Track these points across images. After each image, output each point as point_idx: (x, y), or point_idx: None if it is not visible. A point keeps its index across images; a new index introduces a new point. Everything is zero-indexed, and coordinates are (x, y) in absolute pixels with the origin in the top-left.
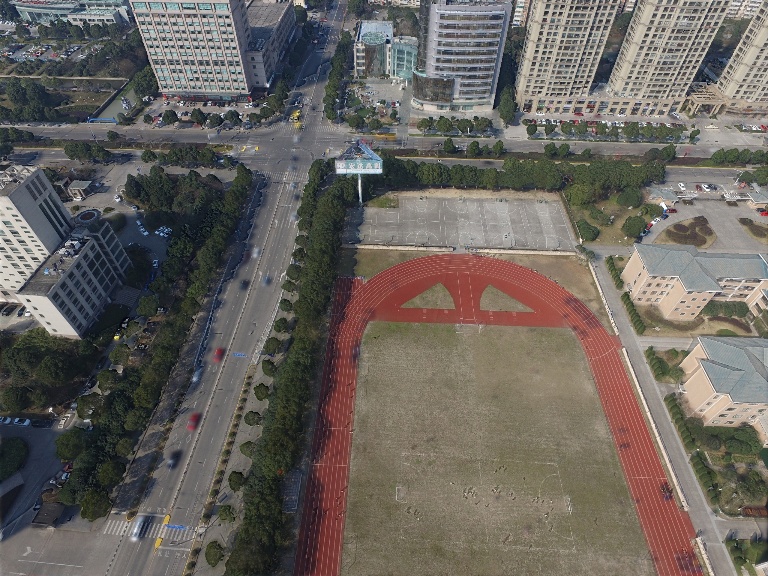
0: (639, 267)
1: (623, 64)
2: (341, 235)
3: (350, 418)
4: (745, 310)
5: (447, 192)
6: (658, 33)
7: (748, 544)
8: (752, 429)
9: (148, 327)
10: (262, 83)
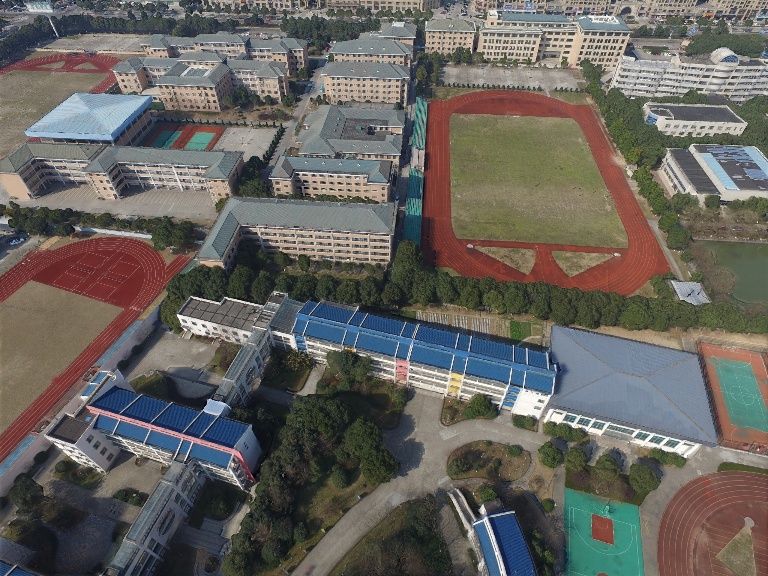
0: None
1: None
2: (34, 47)
3: None
4: None
5: (112, 34)
6: None
7: None
8: None
9: None
10: None
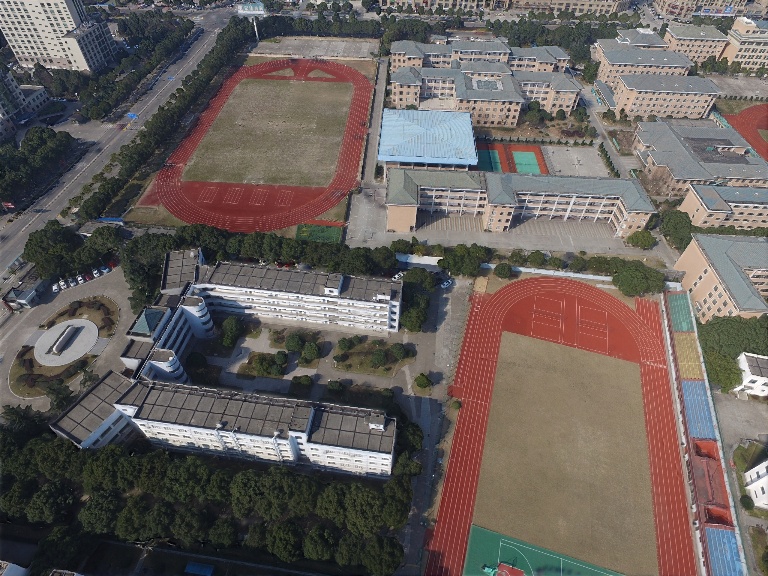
0: None
1: None
2: (242, 51)
3: (223, 104)
4: None
5: (312, 37)
6: None
7: None
8: None
9: None
10: None
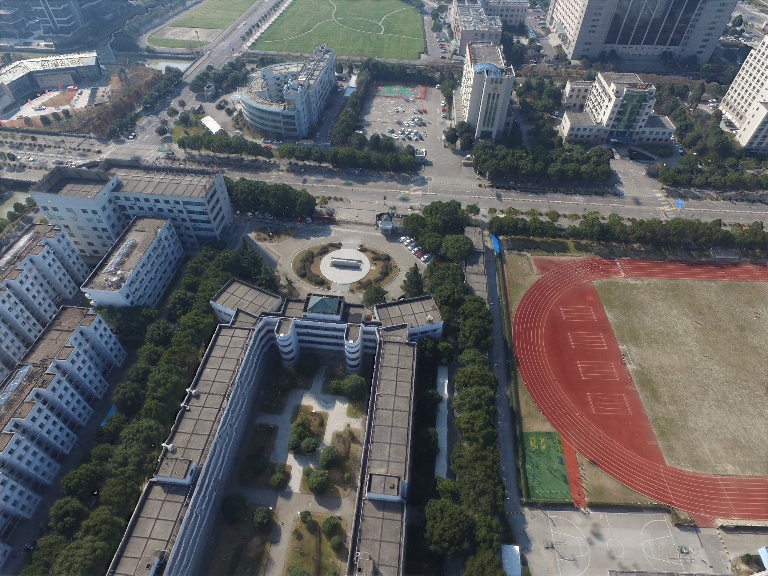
0: None
1: None
2: None
3: None
4: None
5: None
6: None
7: None
8: None
9: None
10: None
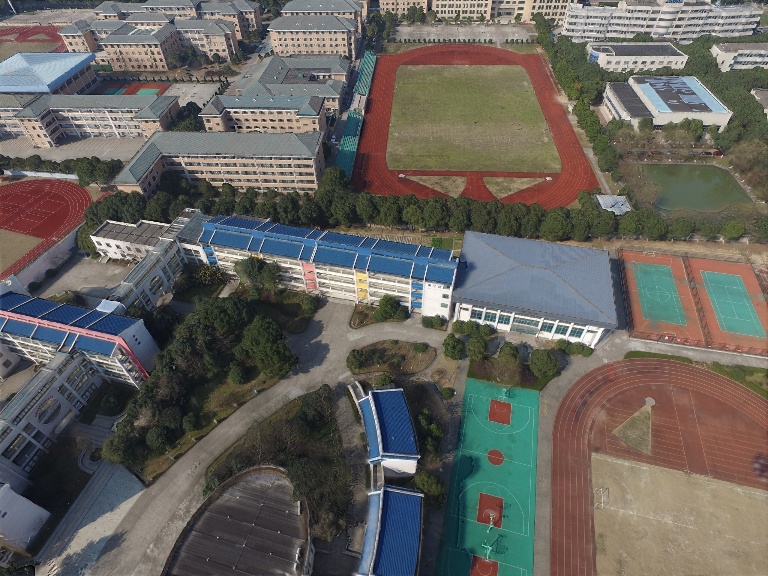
0: None
1: None
2: None
3: None
4: None
5: (70, 10)
6: None
7: None
8: None
9: None
10: None
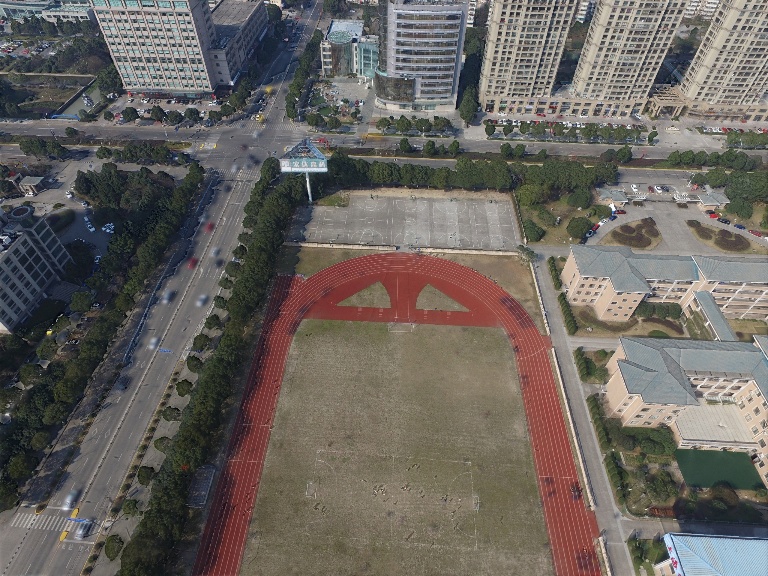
0: (574, 268)
1: (584, 65)
2: (287, 233)
3: (271, 415)
4: (677, 312)
5: (399, 191)
6: (616, 34)
7: (650, 544)
8: (667, 430)
9: (82, 322)
10: (226, 81)
